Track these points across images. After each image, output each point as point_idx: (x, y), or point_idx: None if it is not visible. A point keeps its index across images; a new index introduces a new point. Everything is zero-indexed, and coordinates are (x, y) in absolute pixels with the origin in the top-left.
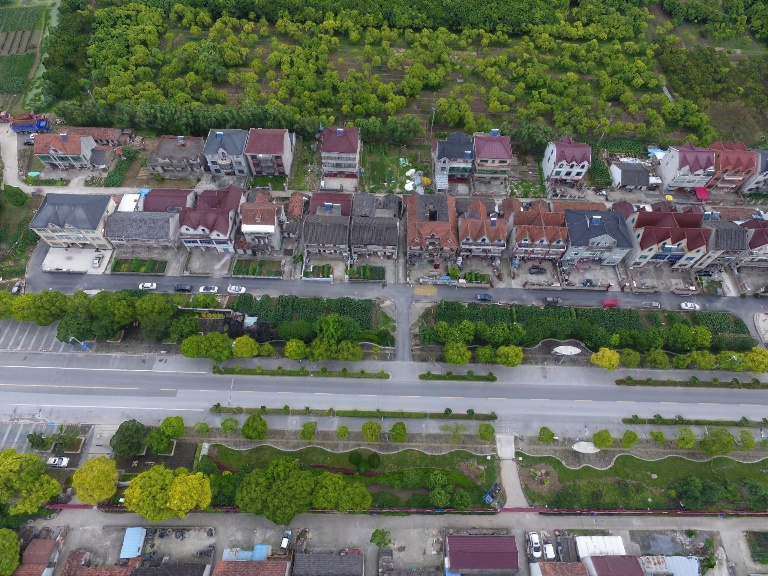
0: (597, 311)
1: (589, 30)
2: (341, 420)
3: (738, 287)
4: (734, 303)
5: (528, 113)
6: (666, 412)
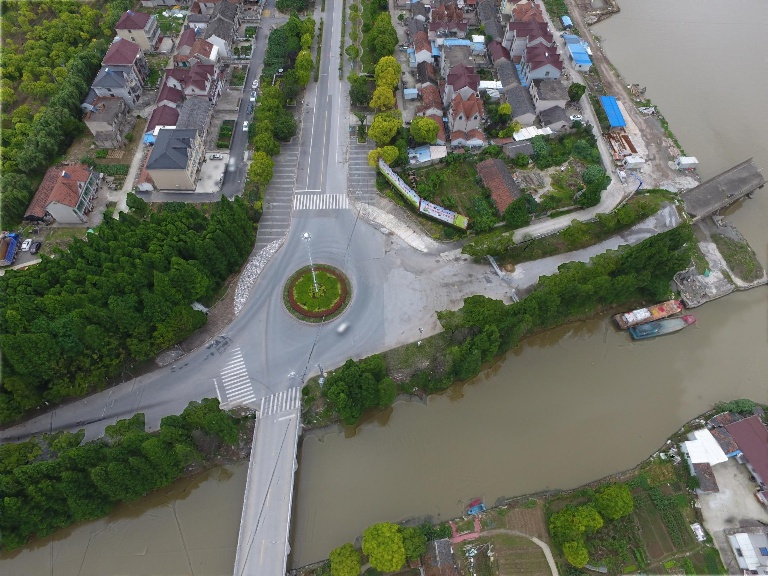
0: None
1: None
2: (346, 36)
3: None
4: None
5: None
6: None
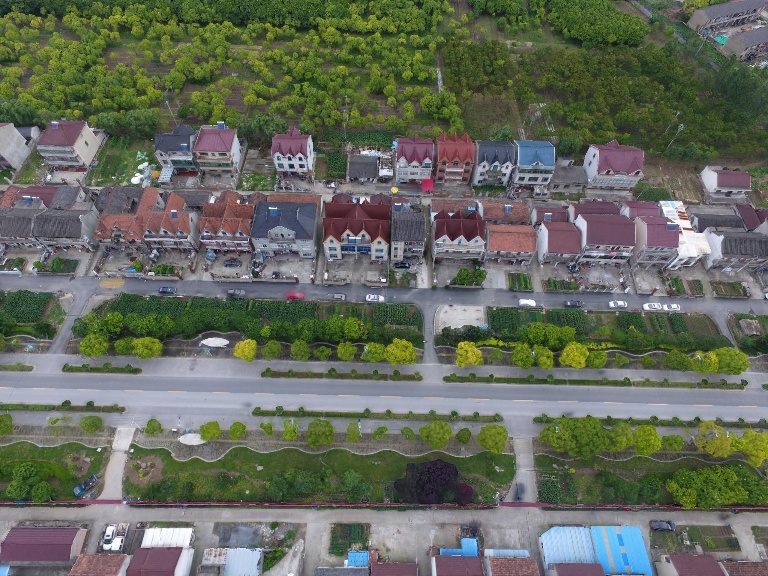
0: (273, 303)
1: (376, 23)
2: None
3: (432, 279)
4: (423, 295)
5: (278, 106)
6: (301, 404)
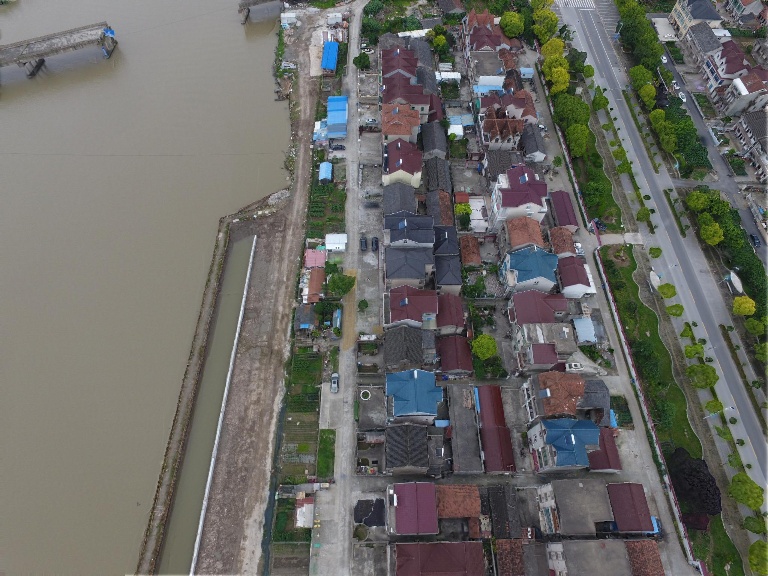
0: None
1: None
2: None
3: None
4: None
5: None
6: None
